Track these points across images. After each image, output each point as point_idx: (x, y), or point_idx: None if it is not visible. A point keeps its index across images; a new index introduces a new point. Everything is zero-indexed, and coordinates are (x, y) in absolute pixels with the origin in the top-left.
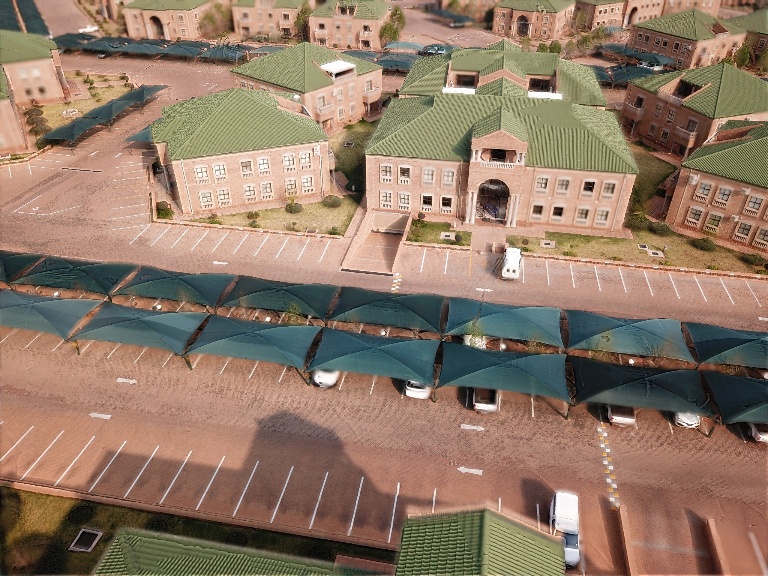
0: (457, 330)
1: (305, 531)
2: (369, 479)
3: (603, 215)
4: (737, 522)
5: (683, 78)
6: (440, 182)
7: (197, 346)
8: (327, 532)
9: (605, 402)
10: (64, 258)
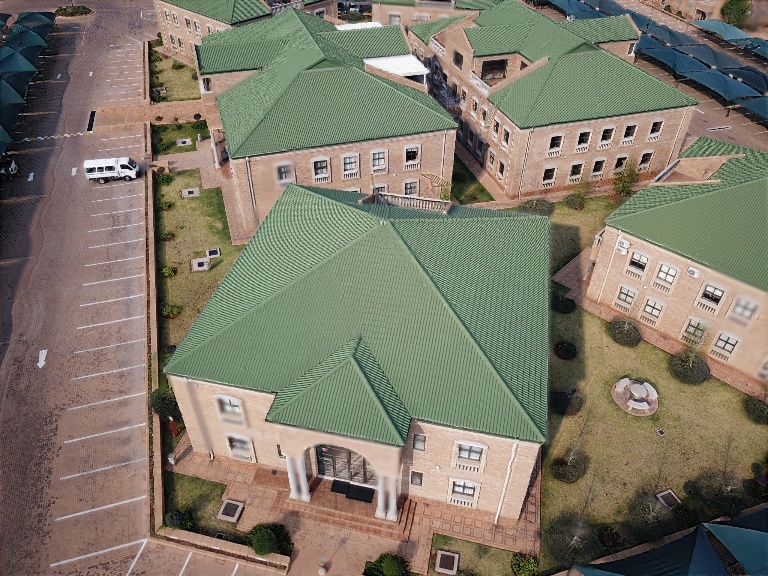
0: None
1: None
2: None
3: None
4: None
5: (730, 160)
6: None
7: None
8: None
9: None
10: (49, 27)
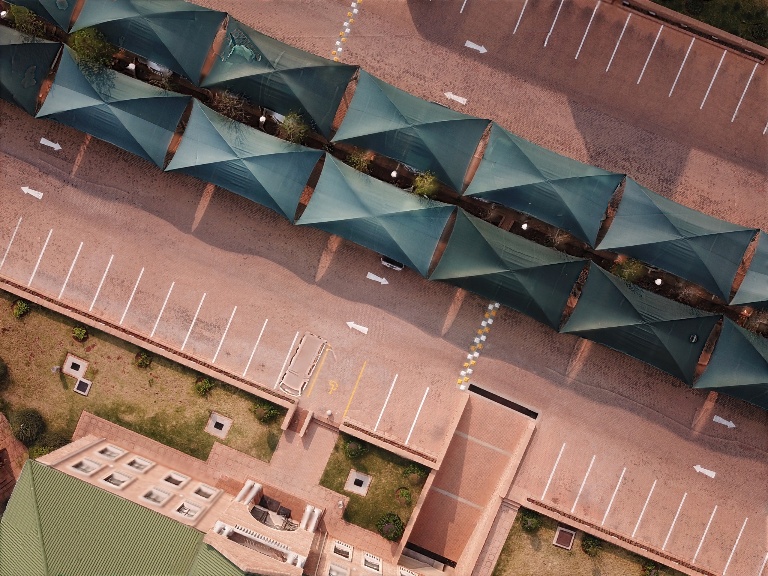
0: (440, 205)
1: (639, 1)
2: (571, 56)
3: (107, 455)
4: None
5: None
6: (351, 575)
7: (745, 238)
8: (617, 7)
9: (328, 60)
10: None
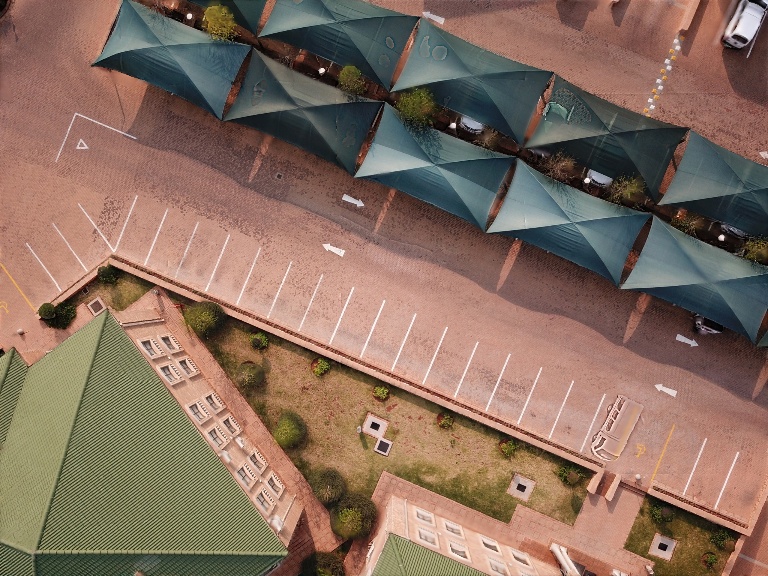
0: None
1: None
2: None
3: (422, 519)
4: (584, 4)
5: None
6: None
7: None
8: None
9: (660, 122)
10: None
